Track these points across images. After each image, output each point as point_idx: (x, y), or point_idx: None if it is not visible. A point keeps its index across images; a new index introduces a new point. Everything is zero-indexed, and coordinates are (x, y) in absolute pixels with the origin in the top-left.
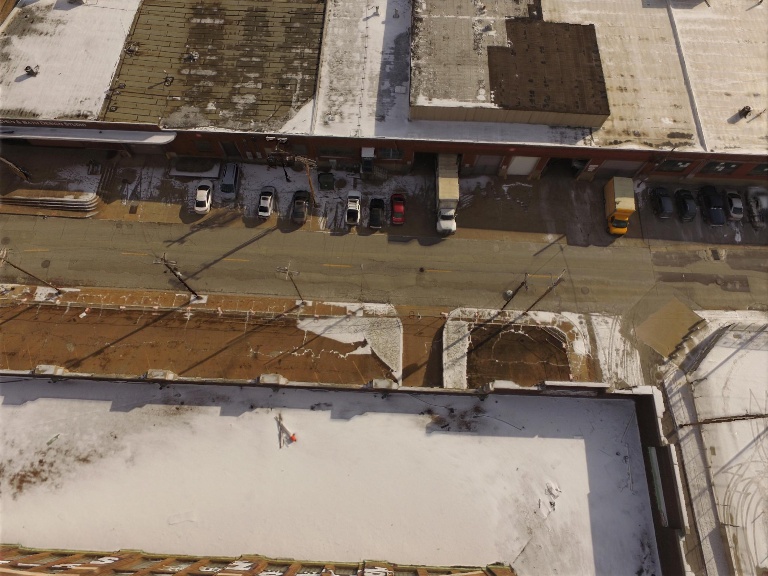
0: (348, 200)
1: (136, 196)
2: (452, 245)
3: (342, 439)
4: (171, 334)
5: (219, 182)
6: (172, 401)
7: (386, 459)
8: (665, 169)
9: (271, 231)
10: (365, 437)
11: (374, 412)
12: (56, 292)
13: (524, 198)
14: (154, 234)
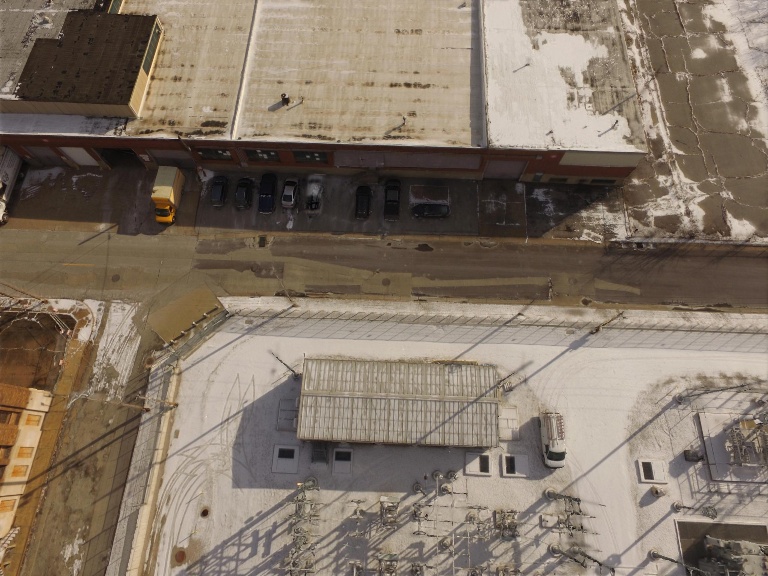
0: None
1: None
2: (1, 235)
3: None
4: None
5: None
6: None
7: None
8: (215, 158)
9: None
10: None
11: None
12: None
13: (90, 188)
14: None
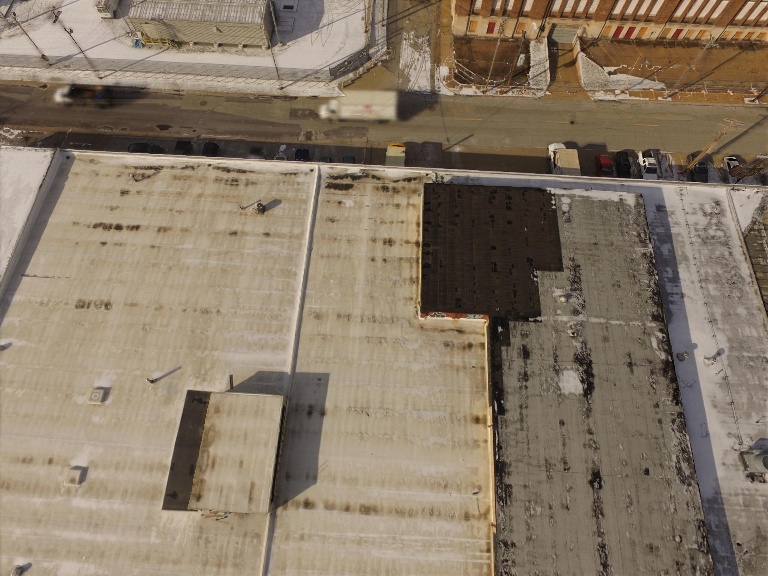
0: None
1: None
2: (547, 142)
3: None
4: (760, 77)
5: None
6: None
7: None
8: None
9: (715, 152)
10: None
11: None
12: None
13: None
14: None
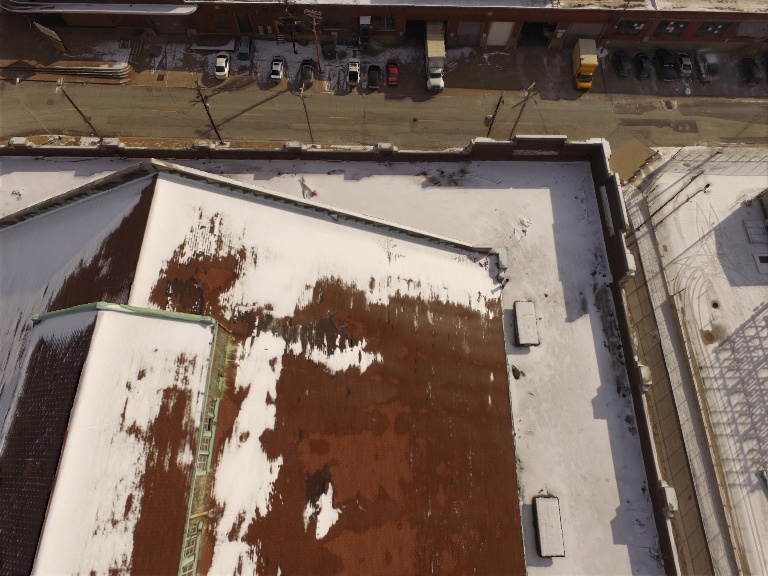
0: (349, 64)
1: (162, 67)
2: (441, 101)
3: (354, 193)
4: None
5: (235, 55)
6: (214, 171)
7: (390, 206)
8: (623, 33)
9: (282, 92)
10: (372, 192)
11: (379, 175)
12: (98, 141)
13: (502, 64)
14: (180, 96)
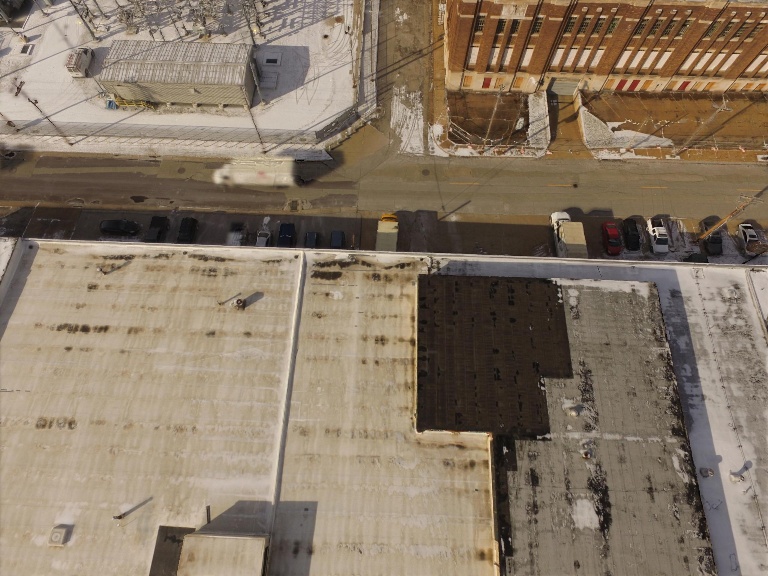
0: None
1: None
2: (550, 209)
3: None
4: None
5: None
6: None
7: None
8: None
9: None
10: None
11: None
12: None
13: None
14: None
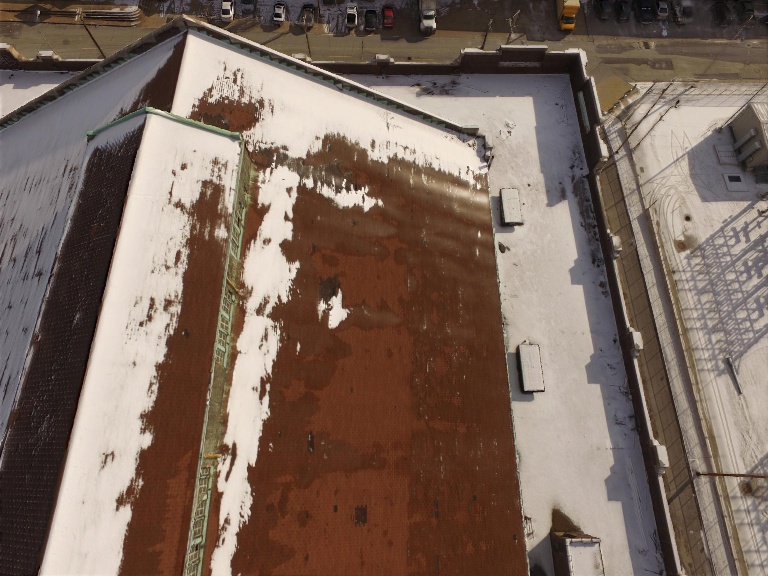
0: (347, 7)
1: (171, 11)
2: (433, 42)
3: None
4: None
5: (239, 0)
6: None
7: None
8: None
9: (285, 34)
10: None
11: (377, 86)
12: None
13: (491, 9)
14: None
